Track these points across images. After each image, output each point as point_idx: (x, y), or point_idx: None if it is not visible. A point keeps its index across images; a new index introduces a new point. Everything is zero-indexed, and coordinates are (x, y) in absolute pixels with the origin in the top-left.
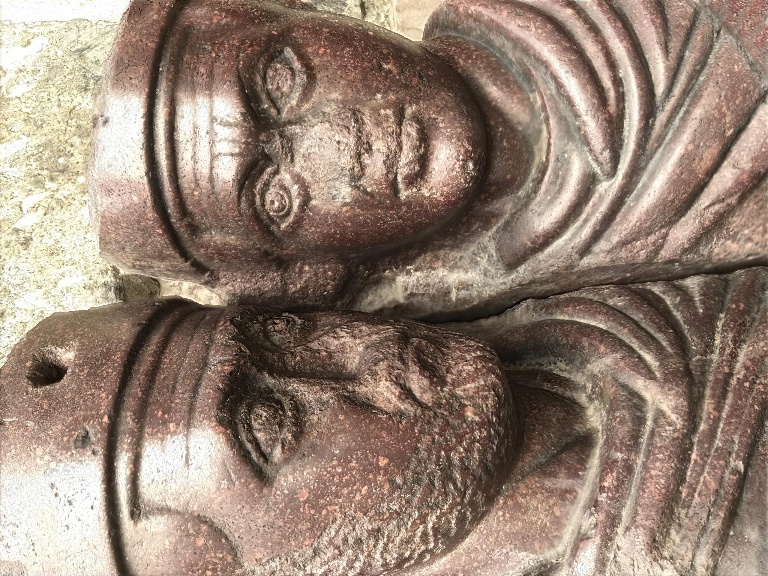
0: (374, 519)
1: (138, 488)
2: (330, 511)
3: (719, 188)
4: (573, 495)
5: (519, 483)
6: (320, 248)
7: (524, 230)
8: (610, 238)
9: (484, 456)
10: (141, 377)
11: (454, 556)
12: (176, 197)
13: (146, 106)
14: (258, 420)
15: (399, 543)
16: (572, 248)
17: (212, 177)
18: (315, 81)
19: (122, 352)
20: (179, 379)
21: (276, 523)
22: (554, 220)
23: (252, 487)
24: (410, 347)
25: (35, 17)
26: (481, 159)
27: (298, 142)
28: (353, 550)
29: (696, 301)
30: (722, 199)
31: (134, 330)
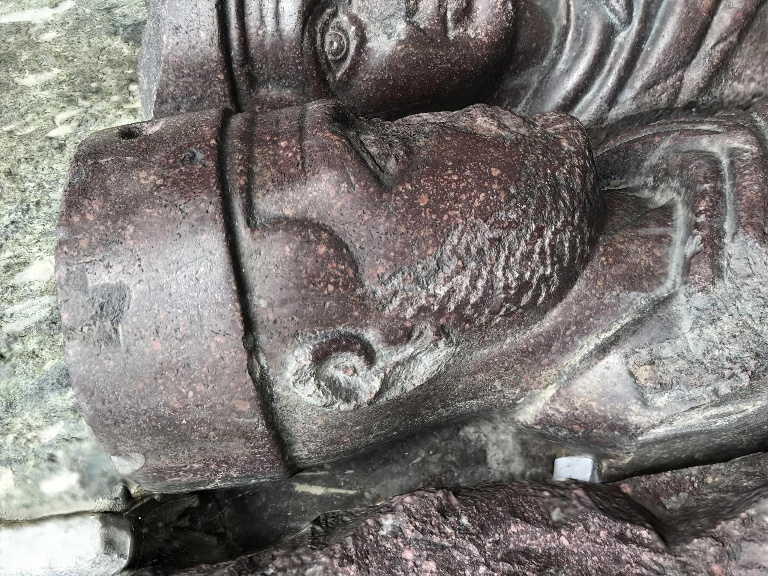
0: (494, 227)
1: (252, 199)
2: (451, 216)
3: (721, 27)
4: (668, 239)
5: (614, 235)
6: (371, 103)
7: (554, 89)
8: (634, 84)
9: (585, 183)
10: (241, 121)
11: (564, 306)
12: (241, 36)
13: None
14: (368, 140)
15: (520, 258)
16: (601, 98)
17: (278, 12)
18: None
19: None
20: (281, 118)
21: (398, 229)
22: (582, 72)
23: (372, 191)
24: None
25: None
26: (516, 6)
27: None
28: (476, 262)
29: None
30: (725, 37)
31: None
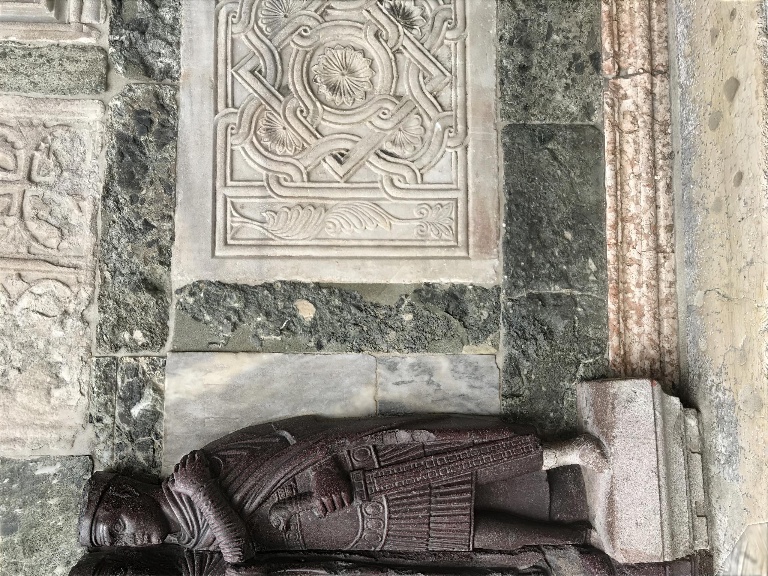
0: None
1: None
2: None
3: None
4: None
5: None
6: None
7: (180, 541)
8: None
9: None
10: None
11: None
12: None
13: None
14: None
15: None
16: (190, 547)
17: None
18: (126, 526)
19: None
20: None
21: None
22: None
23: None
24: None
25: (57, 454)
26: None
27: None
28: None
29: None
30: None
31: None
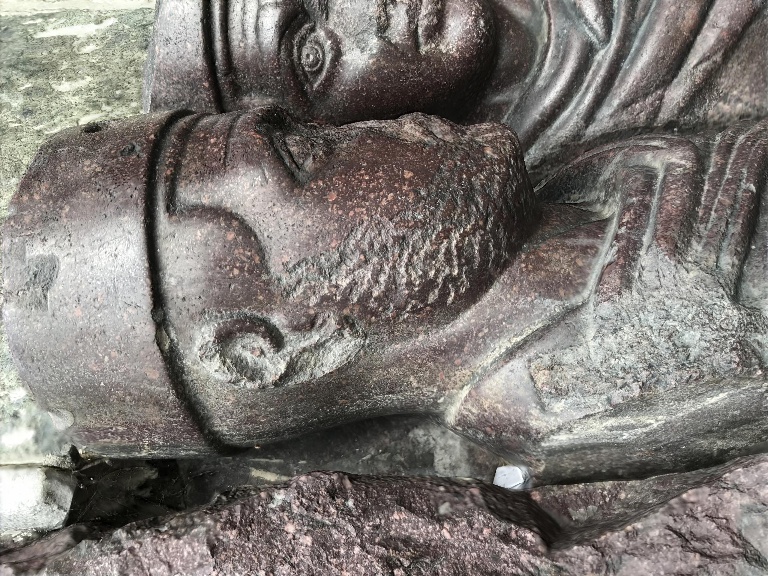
0: (399, 225)
1: (176, 188)
2: (357, 213)
3: (703, 47)
4: (594, 250)
5: (540, 244)
6: (348, 113)
7: (532, 105)
8: (611, 102)
9: (504, 190)
10: (186, 120)
11: (478, 309)
12: (224, 47)
13: None
14: (292, 140)
15: (424, 256)
16: (577, 115)
17: (257, 26)
18: None
19: None
20: None
21: (305, 222)
22: (559, 88)
23: (284, 186)
24: None
25: (109, 7)
26: (491, 24)
27: (333, 0)
28: (378, 258)
29: None
30: (708, 56)
31: None
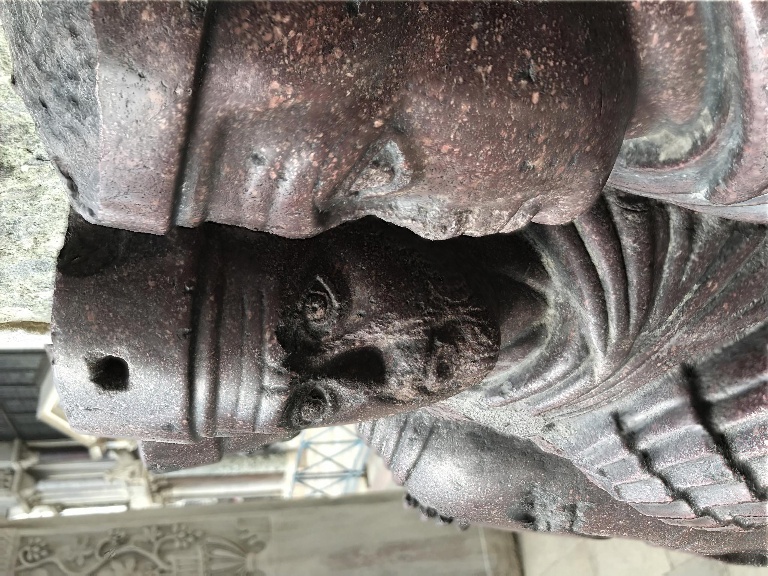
0: None
1: None
2: None
3: None
4: None
5: None
6: None
7: None
8: None
9: None
10: (206, 394)
11: None
12: None
13: (167, 225)
14: (307, 414)
15: None
16: (627, 191)
17: None
18: (421, 179)
19: (182, 375)
20: (241, 397)
21: None
22: (627, 187)
23: None
24: (434, 359)
25: None
26: None
27: None
28: None
29: (690, 261)
30: None
31: (183, 345)
